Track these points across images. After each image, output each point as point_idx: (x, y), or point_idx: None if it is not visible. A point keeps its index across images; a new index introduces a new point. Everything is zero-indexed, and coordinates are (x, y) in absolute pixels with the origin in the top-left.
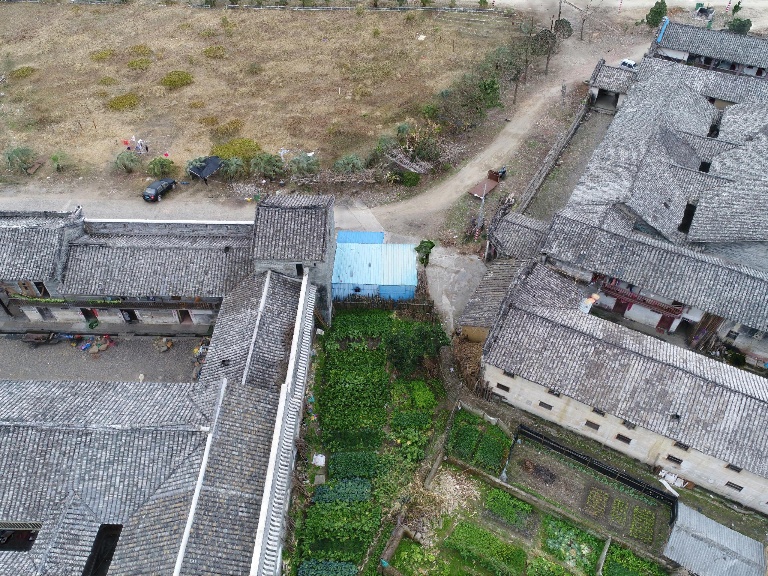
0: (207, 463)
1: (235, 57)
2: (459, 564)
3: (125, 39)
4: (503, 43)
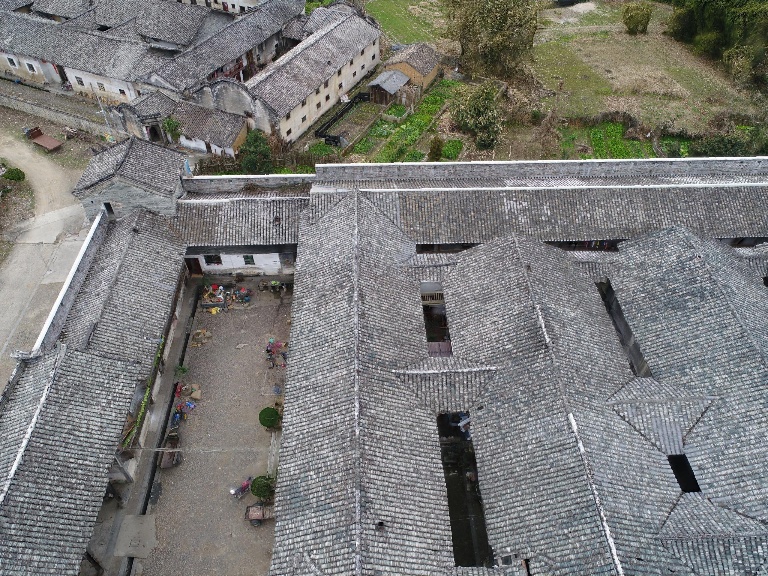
0: None
1: None
2: None
3: None
4: None
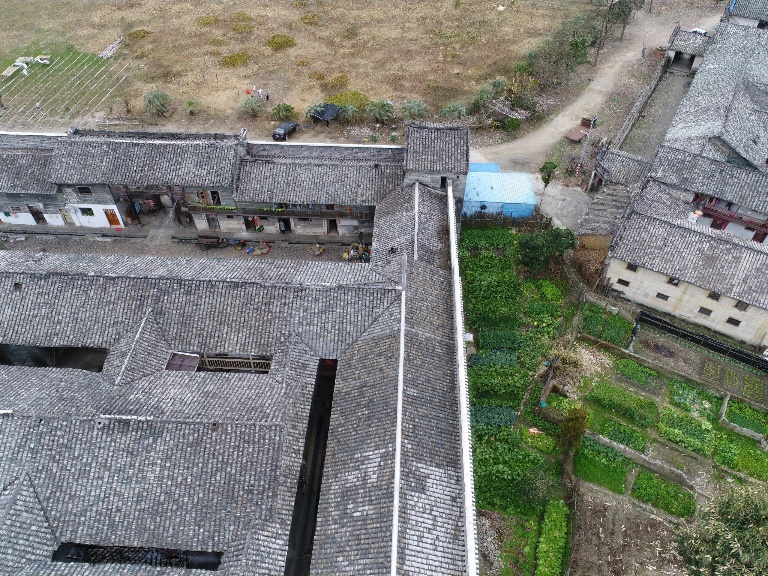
0: (405, 312)
1: (329, 24)
2: (601, 412)
3: (225, 8)
4: (577, 14)
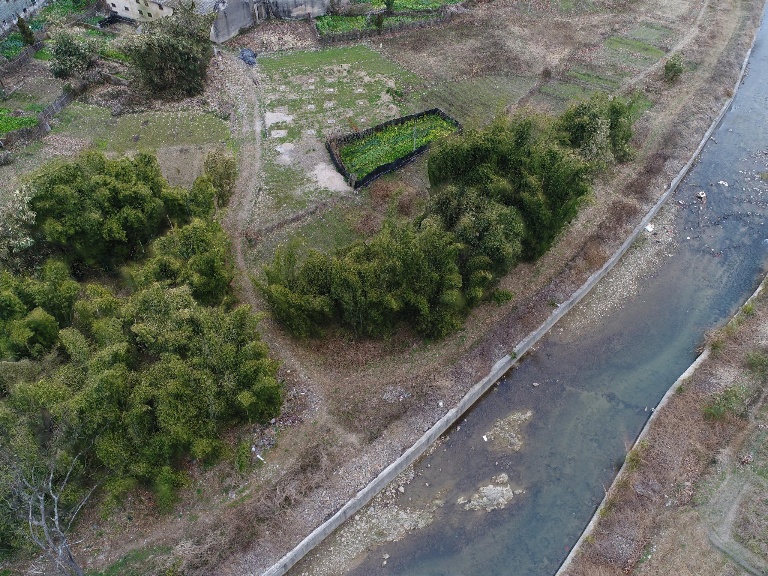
0: None
1: None
2: None
3: None
4: None
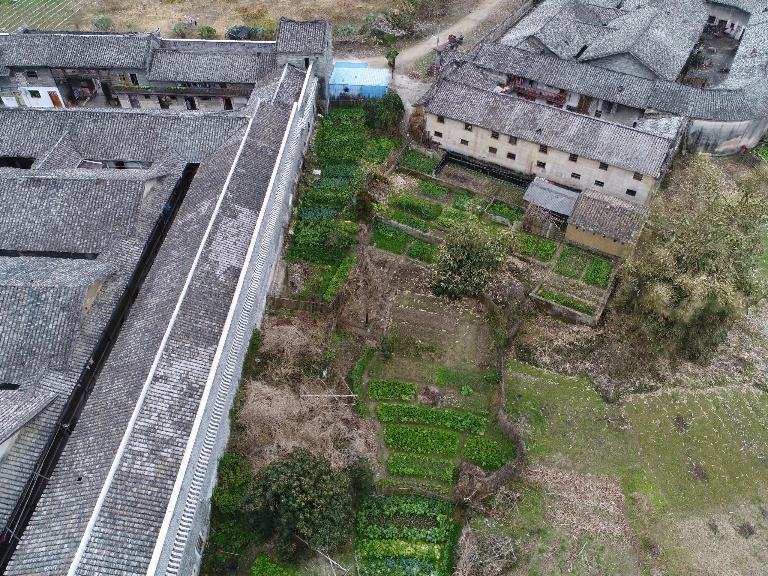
0: (250, 130)
1: None
2: (400, 212)
3: None
4: None
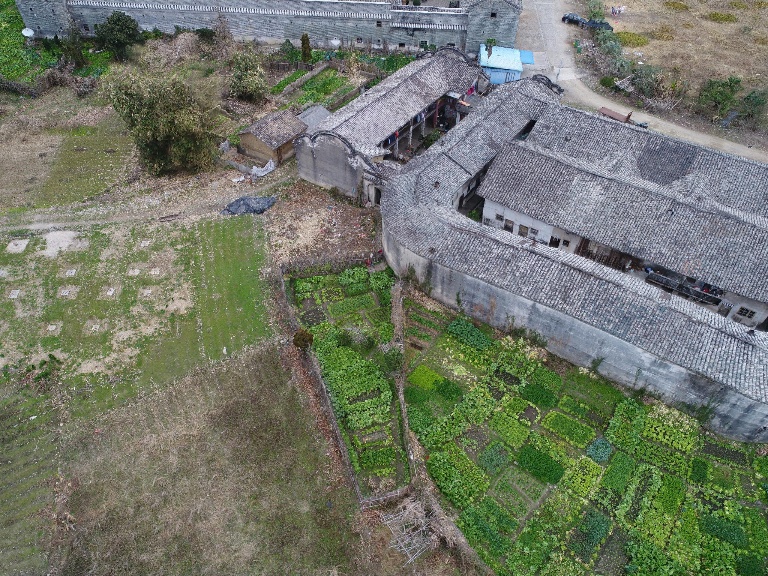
0: None
1: None
2: None
3: None
4: None
